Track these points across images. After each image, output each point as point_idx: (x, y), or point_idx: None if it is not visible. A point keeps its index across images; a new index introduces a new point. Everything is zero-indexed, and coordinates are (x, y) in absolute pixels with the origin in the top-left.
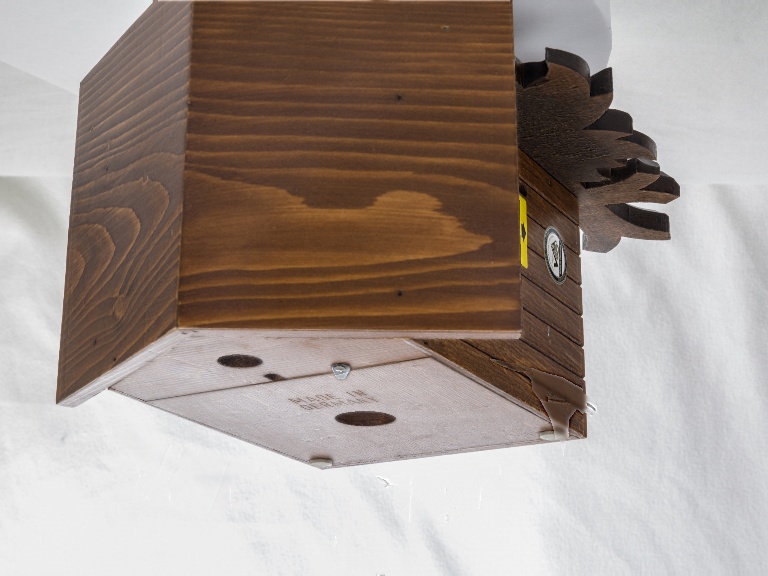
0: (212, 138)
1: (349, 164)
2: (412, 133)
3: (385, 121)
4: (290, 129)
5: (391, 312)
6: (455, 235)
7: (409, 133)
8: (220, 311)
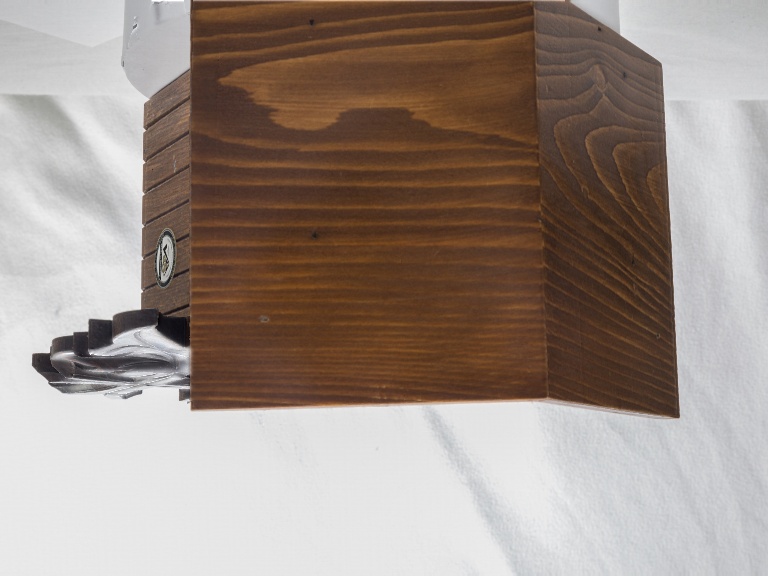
0: (512, 181)
1: (366, 157)
2: (301, 194)
3: (330, 207)
4: (430, 194)
5: (320, 3)
6: (256, 85)
7: (304, 194)
8: None
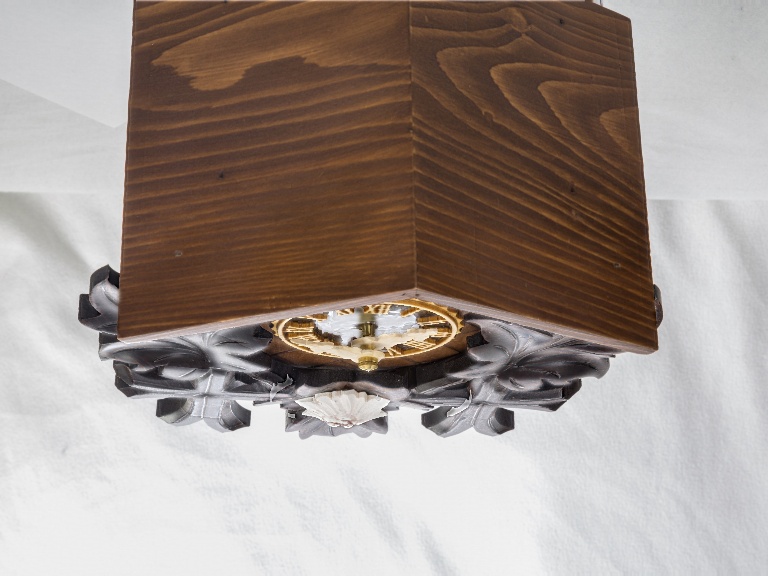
0: (387, 100)
1: (265, 103)
2: (211, 143)
3: (234, 150)
4: (317, 124)
5: None
6: (180, 60)
7: (214, 143)
8: None
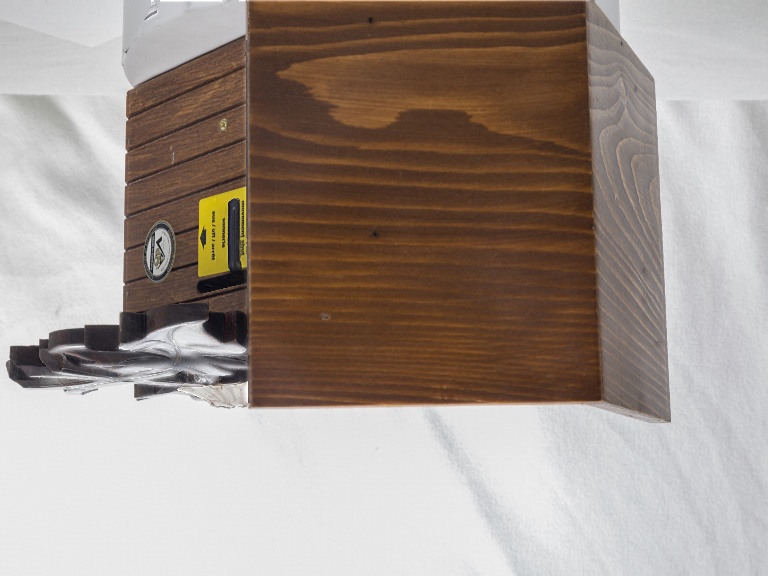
0: (567, 188)
1: (426, 158)
2: (361, 192)
3: (390, 206)
4: (488, 197)
5: (379, 1)
6: (315, 80)
7: (364, 192)
8: (545, 6)
